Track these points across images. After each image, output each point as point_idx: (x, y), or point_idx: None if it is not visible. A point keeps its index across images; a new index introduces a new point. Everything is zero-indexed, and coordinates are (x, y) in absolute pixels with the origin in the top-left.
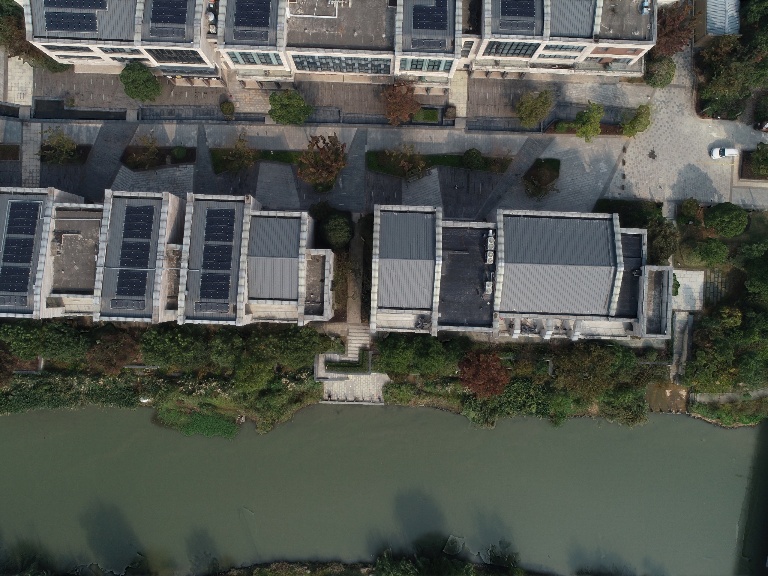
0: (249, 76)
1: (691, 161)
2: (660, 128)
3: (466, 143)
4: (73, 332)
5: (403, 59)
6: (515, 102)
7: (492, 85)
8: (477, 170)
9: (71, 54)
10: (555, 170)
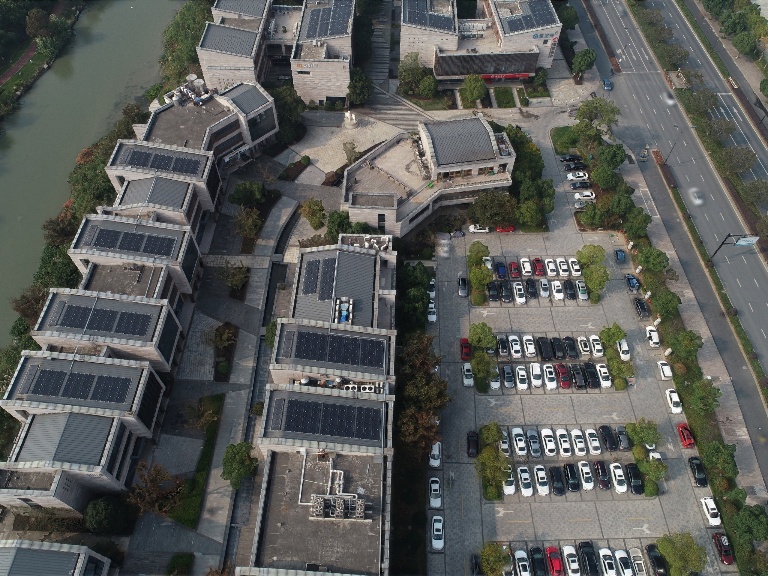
0: None
1: None
2: None
3: None
4: (72, 282)
5: None
6: None
7: None
8: None
9: None
10: None
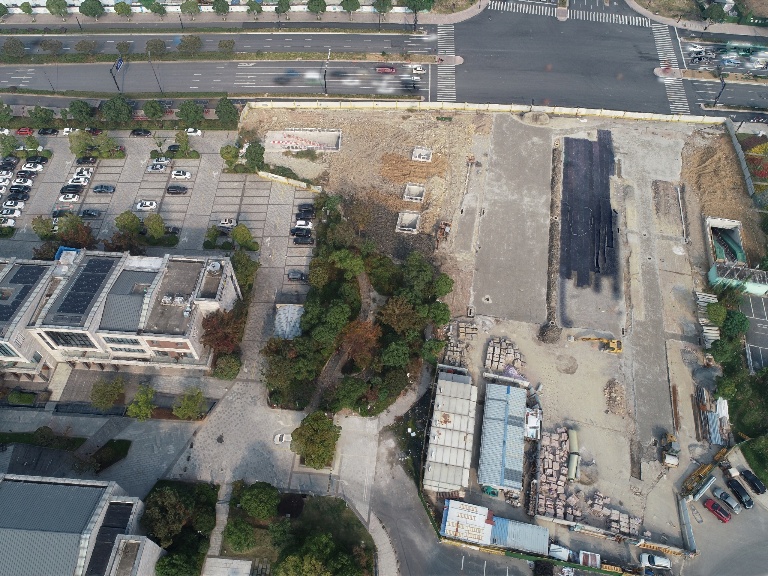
0: None
1: (256, 446)
2: (232, 416)
3: (50, 423)
4: None
5: None
6: None
7: (91, 375)
8: (50, 448)
9: None
10: (122, 450)
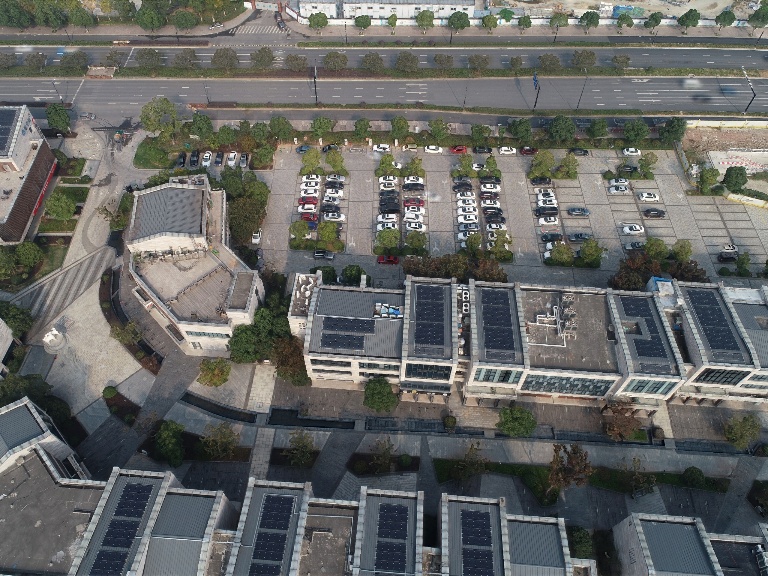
0: (477, 393)
1: None
2: None
3: (680, 462)
4: None
5: (630, 380)
6: (716, 426)
7: (690, 411)
8: (698, 489)
9: (328, 368)
10: None
